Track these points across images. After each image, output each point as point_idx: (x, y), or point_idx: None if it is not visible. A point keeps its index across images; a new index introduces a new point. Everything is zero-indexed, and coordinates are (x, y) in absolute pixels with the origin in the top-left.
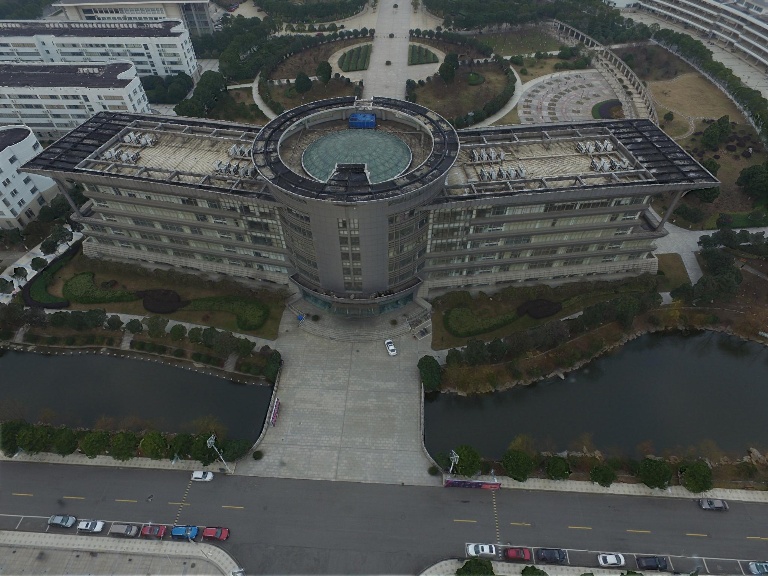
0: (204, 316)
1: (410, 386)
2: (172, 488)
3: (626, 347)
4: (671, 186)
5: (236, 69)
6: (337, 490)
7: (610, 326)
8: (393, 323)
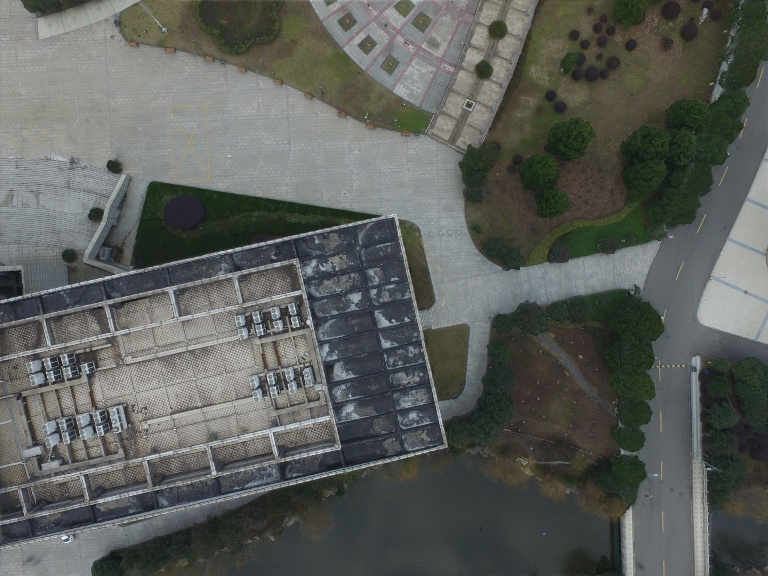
0: None
1: None
2: None
3: None
4: None
5: None
6: None
7: None
8: None
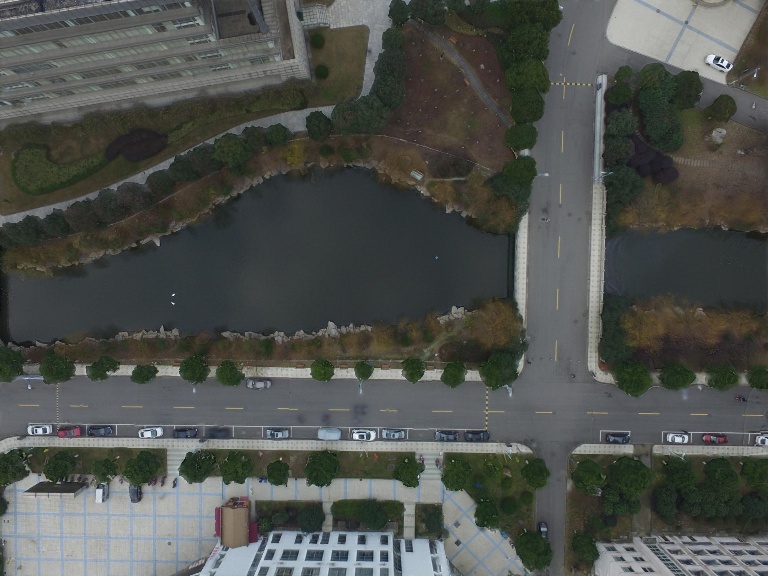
0: None
1: None
2: None
3: (264, 185)
4: None
5: None
6: None
7: (227, 169)
8: None
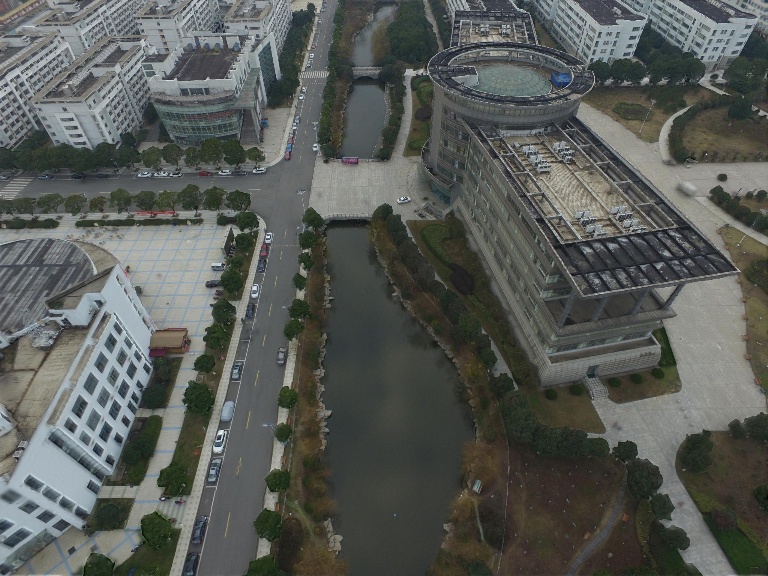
0: (414, 128)
1: None
2: (310, 142)
3: None
4: None
5: (737, 77)
6: (306, 188)
7: None
8: (424, 198)
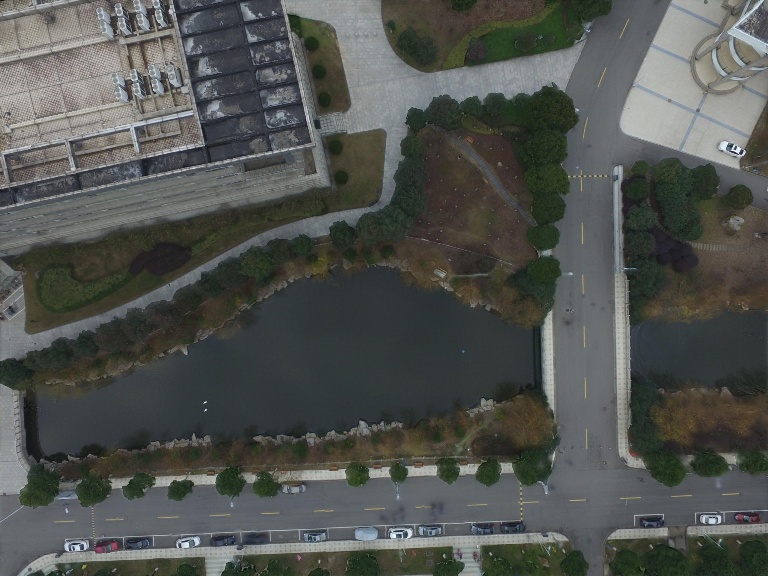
0: None
1: (3, 387)
2: None
3: None
4: (221, 164)
5: None
6: None
7: None
8: None
